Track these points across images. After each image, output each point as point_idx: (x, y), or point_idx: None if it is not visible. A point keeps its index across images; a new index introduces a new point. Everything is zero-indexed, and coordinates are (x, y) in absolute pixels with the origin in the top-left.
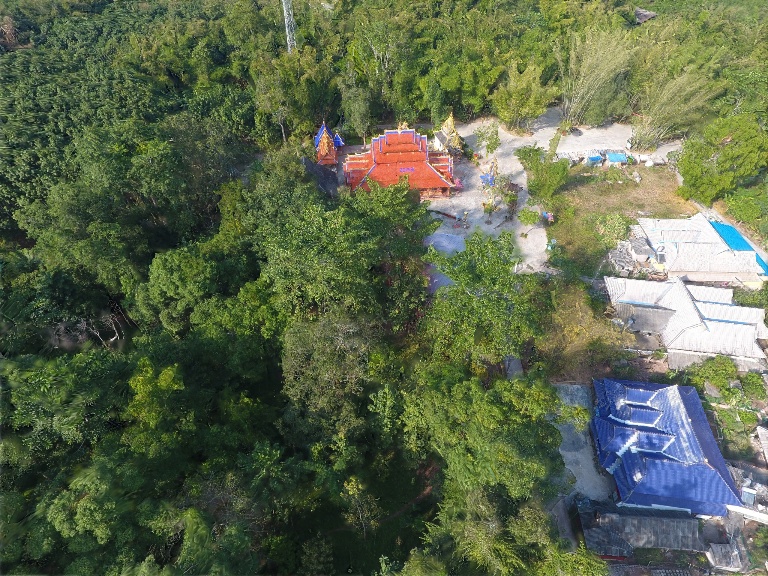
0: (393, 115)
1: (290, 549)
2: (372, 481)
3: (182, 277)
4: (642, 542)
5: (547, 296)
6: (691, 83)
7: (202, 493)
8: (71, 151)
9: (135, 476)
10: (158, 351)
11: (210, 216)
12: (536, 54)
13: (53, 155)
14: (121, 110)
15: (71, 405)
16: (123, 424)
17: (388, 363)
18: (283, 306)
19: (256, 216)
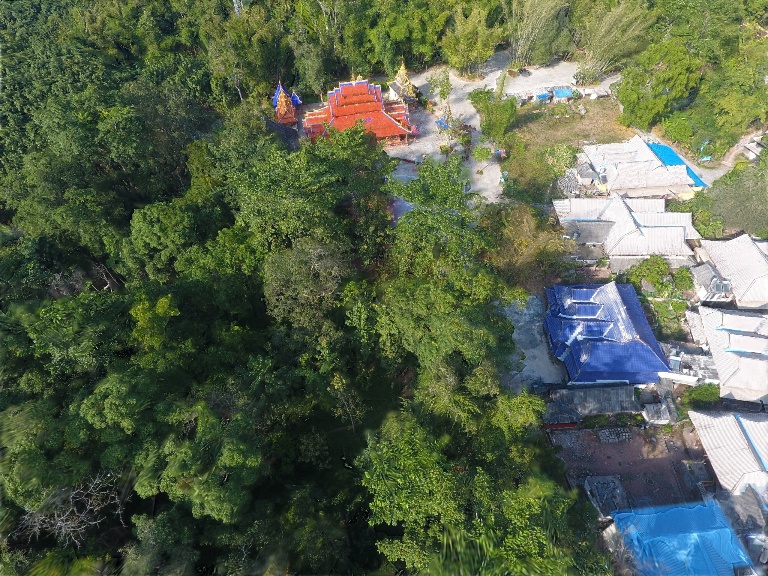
0: (347, 71)
1: (290, 443)
2: (357, 391)
3: (162, 228)
4: (589, 410)
5: (502, 222)
6: (627, 14)
7: (208, 396)
8: (32, 128)
9: (148, 384)
10: (150, 292)
11: (180, 178)
12: None
13: (15, 133)
14: (75, 85)
15: (82, 334)
16: (130, 348)
17: (361, 291)
18: (259, 244)
19: (224, 168)
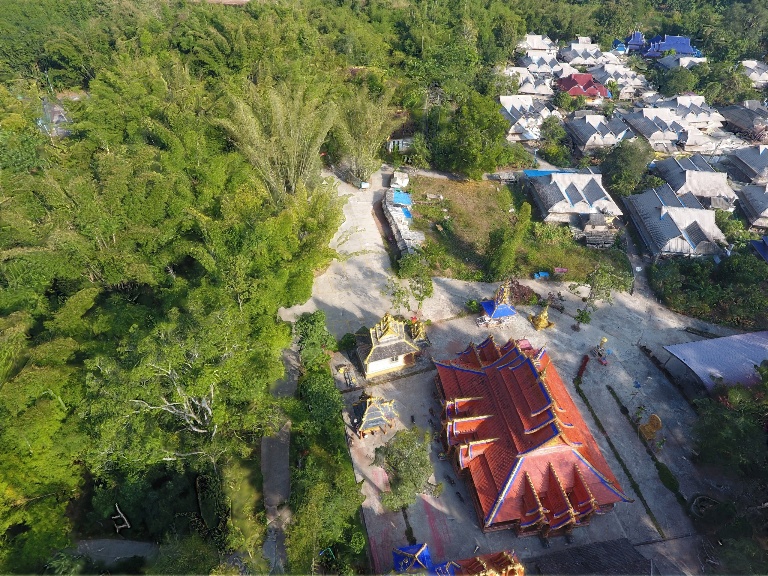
0: None
1: None
2: None
3: None
4: None
5: None
6: None
7: None
8: None
9: None
10: None
11: None
12: (221, 173)
13: None
14: None
15: None
16: None
17: None
18: None
19: None
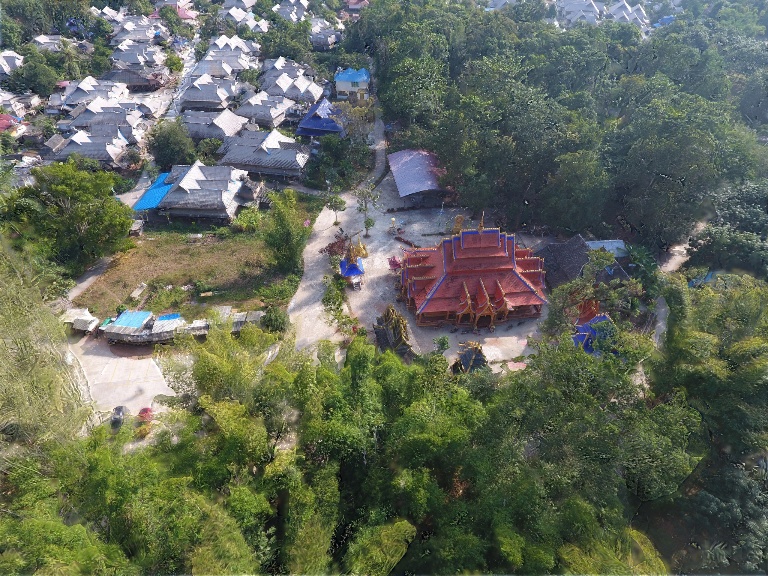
0: None
1: None
2: None
3: None
4: None
5: None
6: None
7: None
8: None
9: None
10: None
11: None
12: None
13: None
14: None
15: None
16: None
17: None
18: None
19: None
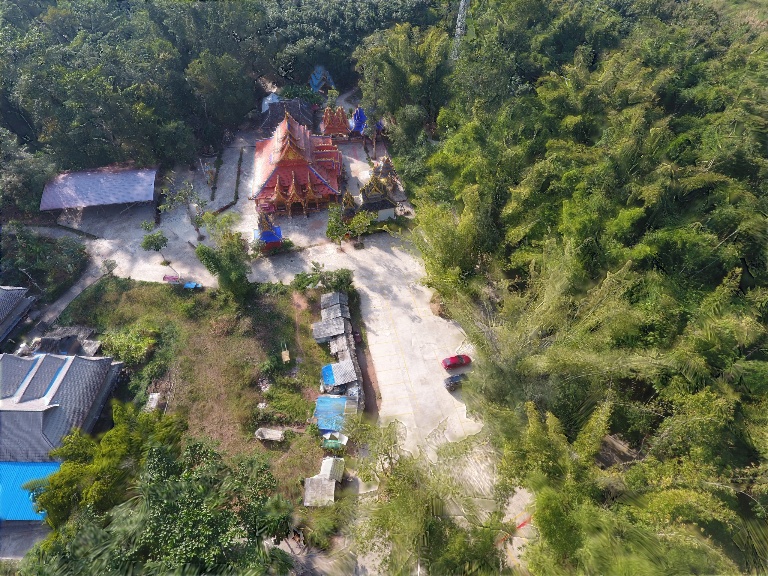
0: None
1: None
2: None
3: None
4: None
5: None
6: None
7: None
8: None
9: None
10: None
11: None
12: None
13: (268, 8)
14: None
15: None
16: None
17: None
18: None
19: None
